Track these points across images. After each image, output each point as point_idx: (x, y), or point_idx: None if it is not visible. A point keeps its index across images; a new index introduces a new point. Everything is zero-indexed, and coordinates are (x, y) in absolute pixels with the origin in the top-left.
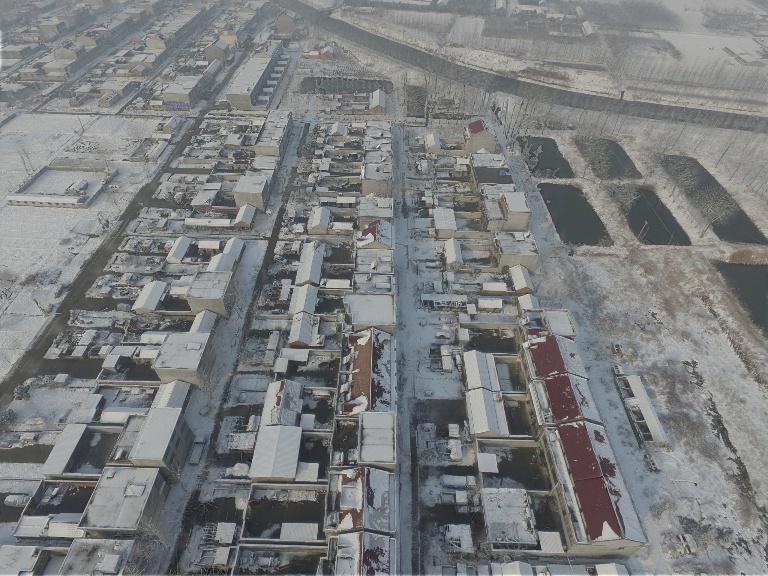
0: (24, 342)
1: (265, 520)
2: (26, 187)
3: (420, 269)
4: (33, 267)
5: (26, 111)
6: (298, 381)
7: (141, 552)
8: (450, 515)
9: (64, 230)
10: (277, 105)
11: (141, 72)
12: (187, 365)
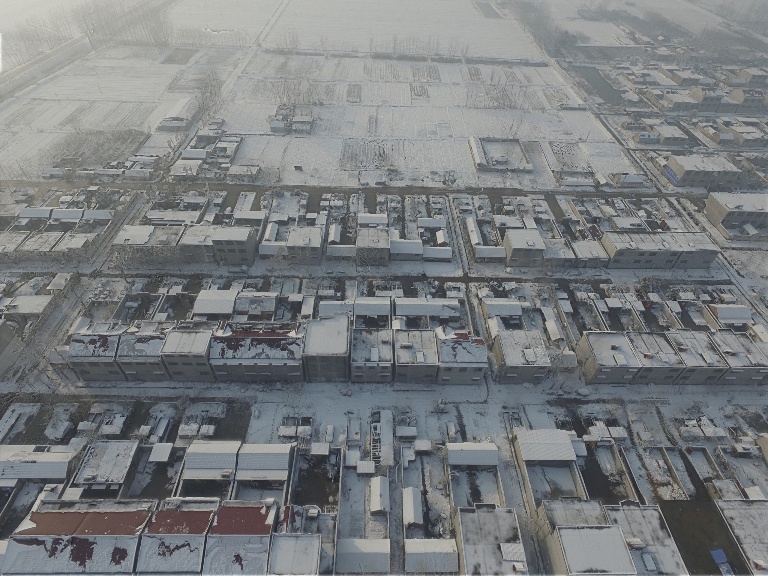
0: (337, 184)
1: (179, 309)
2: (491, 141)
3: (443, 416)
4: (406, 168)
5: (595, 111)
6: (287, 315)
7: (164, 248)
8: (137, 423)
9: (447, 169)
10: (755, 247)
11: (721, 139)
12: (290, 241)
